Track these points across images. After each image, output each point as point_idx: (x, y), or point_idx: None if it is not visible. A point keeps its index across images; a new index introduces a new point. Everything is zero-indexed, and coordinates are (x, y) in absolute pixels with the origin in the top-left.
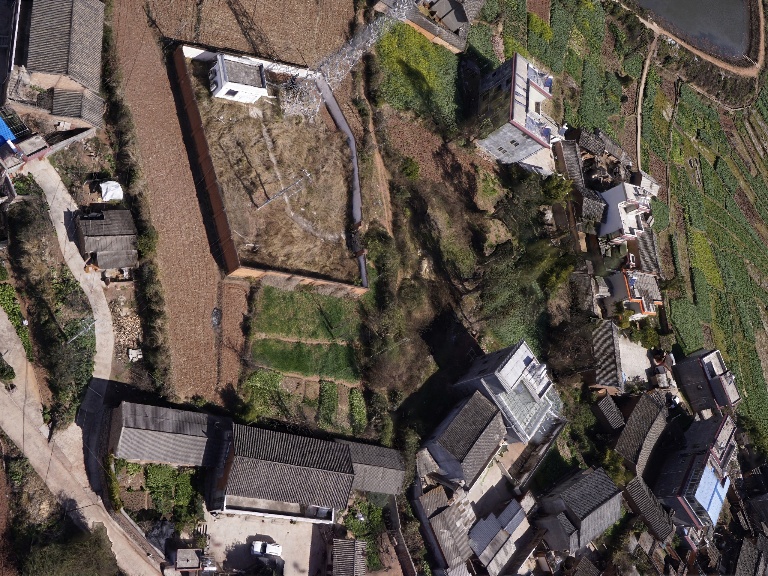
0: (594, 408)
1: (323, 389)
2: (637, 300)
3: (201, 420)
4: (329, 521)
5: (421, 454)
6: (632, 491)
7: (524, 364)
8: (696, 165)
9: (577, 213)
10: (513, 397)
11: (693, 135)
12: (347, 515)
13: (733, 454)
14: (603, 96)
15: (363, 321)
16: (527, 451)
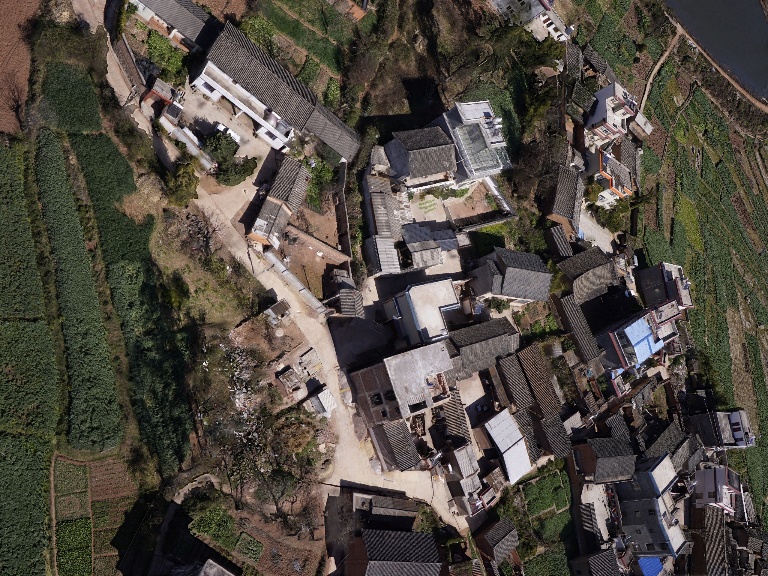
0: (547, 235)
1: (308, 61)
2: (607, 176)
3: (204, 14)
4: (285, 137)
5: (377, 149)
6: (566, 306)
7: (483, 114)
8: (698, 154)
9: (568, 95)
10: (469, 143)
11: (700, 131)
12: (302, 160)
13: (680, 369)
14: (617, 46)
15: (355, 40)
16: (474, 219)
